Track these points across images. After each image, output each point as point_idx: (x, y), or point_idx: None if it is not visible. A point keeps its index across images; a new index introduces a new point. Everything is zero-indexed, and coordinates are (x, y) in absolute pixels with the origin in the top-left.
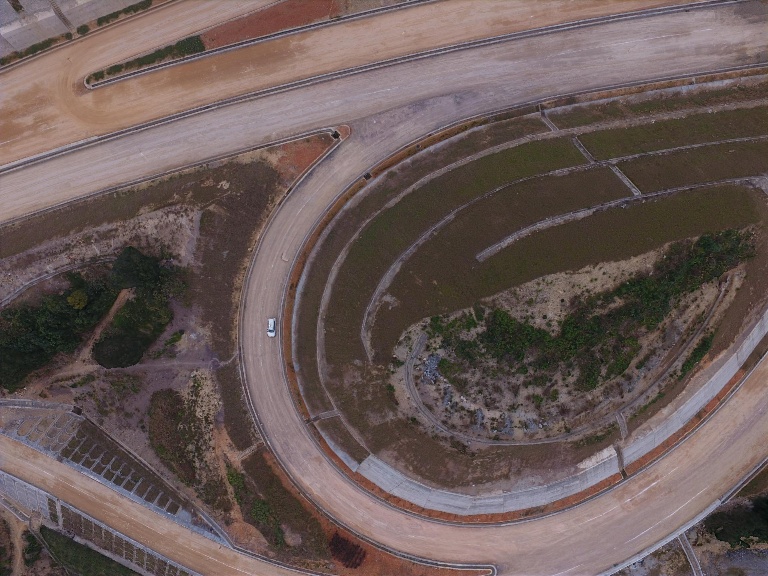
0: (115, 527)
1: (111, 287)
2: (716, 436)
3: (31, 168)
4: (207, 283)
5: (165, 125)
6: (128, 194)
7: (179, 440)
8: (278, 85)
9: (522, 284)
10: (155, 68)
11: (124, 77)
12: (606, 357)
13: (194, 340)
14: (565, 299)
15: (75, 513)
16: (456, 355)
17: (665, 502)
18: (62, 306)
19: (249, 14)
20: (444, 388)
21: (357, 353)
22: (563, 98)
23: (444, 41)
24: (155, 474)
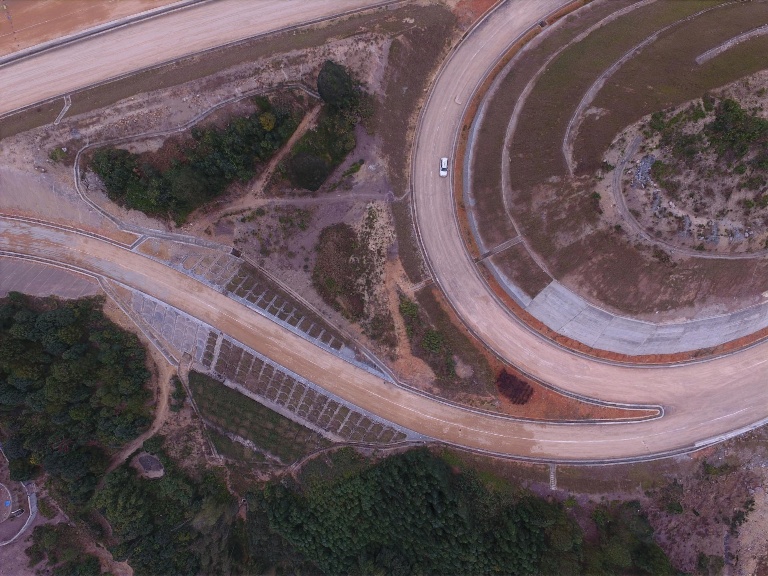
0: (278, 361)
1: (294, 115)
2: None
3: (212, 4)
4: (388, 115)
5: None
6: (307, 32)
7: (350, 272)
8: None
9: (756, 72)
10: None
11: None
12: None
13: (372, 171)
14: None
15: (237, 347)
16: (672, 155)
17: None
18: (254, 123)
19: None
20: (654, 193)
21: (556, 168)
22: None
23: None
24: (316, 314)
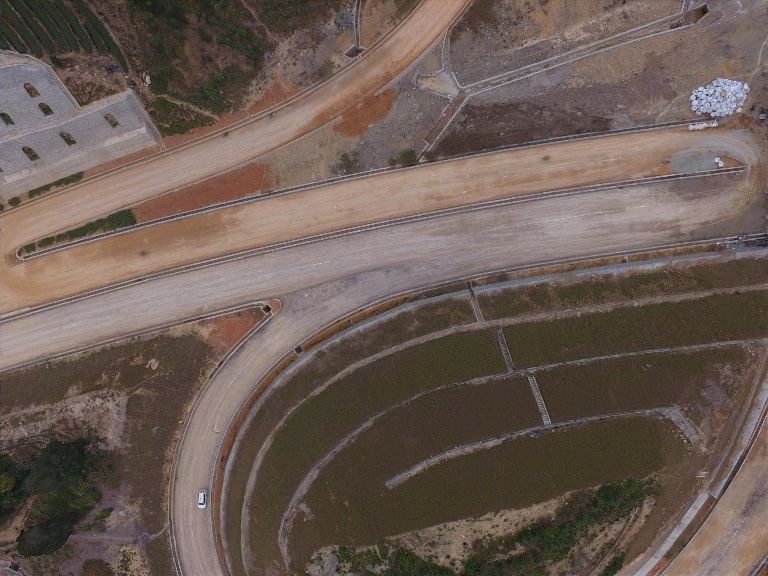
0: None
1: None
2: None
3: None
4: (136, 461)
5: (97, 296)
6: (60, 365)
7: None
8: (210, 258)
9: (424, 528)
10: (86, 241)
11: (55, 249)
12: None
13: (123, 517)
14: (467, 542)
15: None
16: None
17: None
18: None
19: (180, 189)
20: None
21: (275, 556)
22: (495, 275)
23: (376, 216)
24: None
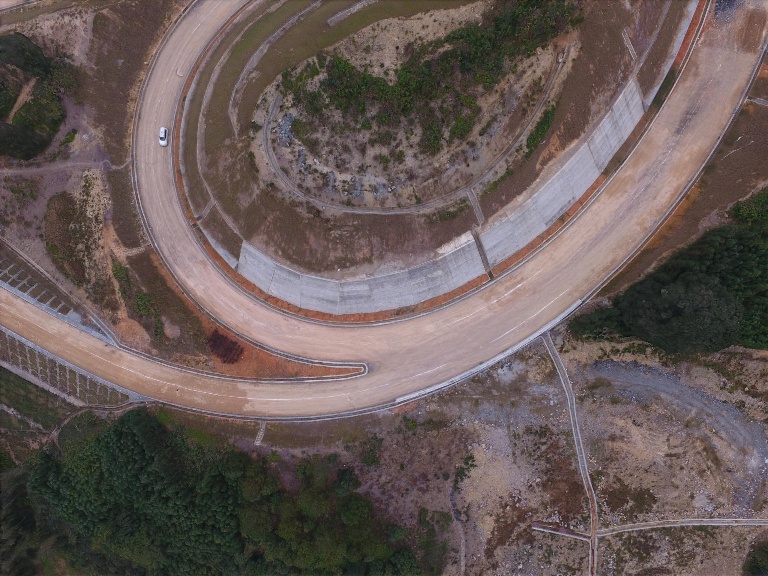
0: (8, 326)
1: (10, 88)
2: (579, 239)
3: None
4: (101, 87)
5: None
6: (34, 9)
7: (70, 239)
8: None
9: (359, 30)
10: None
11: None
12: (447, 118)
13: (86, 141)
14: (400, 47)
15: None
16: (307, 113)
17: (529, 303)
18: None
19: None
20: (298, 150)
21: (226, 131)
22: None
23: None
24: (51, 281)
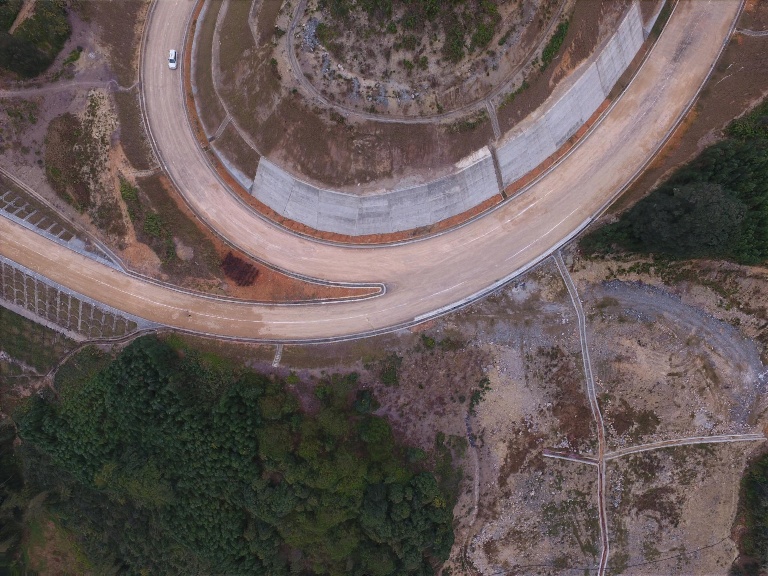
0: (4, 254)
1: (10, 3)
2: (586, 161)
3: None
4: (108, 5)
5: None
6: None
7: (74, 161)
8: None
9: None
10: None
11: None
12: (469, 25)
13: (92, 59)
14: None
15: None
16: (332, 17)
17: (542, 221)
18: None
19: None
20: (322, 56)
21: (245, 41)
22: None
23: None
24: (50, 208)
